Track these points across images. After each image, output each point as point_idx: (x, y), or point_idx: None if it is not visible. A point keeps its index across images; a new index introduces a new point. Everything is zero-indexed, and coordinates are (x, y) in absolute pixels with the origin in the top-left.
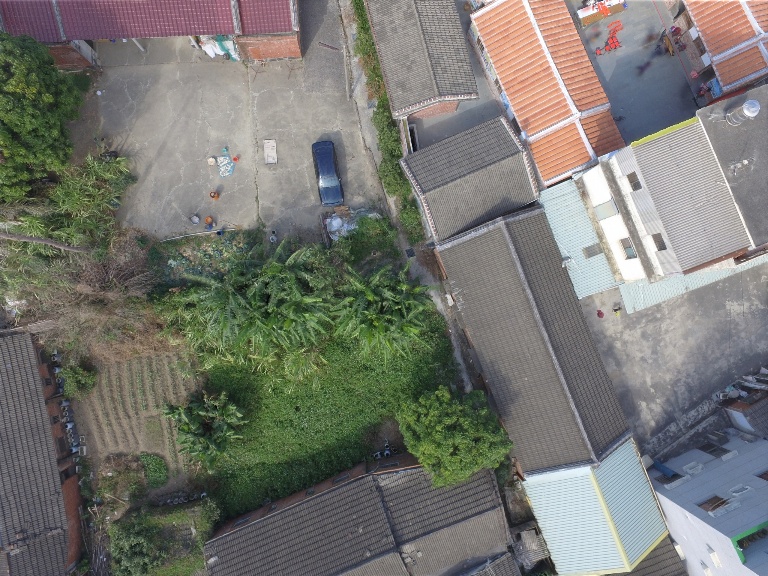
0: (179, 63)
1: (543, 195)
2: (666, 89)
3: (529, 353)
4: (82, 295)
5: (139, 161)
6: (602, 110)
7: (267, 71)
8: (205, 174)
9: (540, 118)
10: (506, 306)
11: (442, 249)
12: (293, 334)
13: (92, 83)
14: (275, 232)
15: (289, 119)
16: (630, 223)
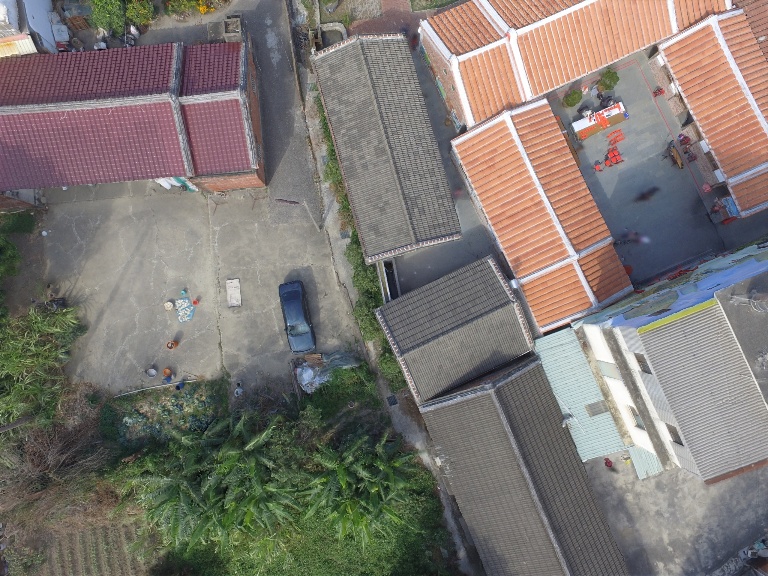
0: (132, 197)
1: (539, 344)
2: (675, 204)
3: (527, 535)
4: (21, 479)
5: (89, 308)
6: (603, 245)
7: (228, 202)
8: (162, 320)
9: (533, 258)
10: (499, 480)
11: (425, 411)
12: (257, 521)
13: (37, 223)
14: (240, 384)
15: (254, 255)
16: (639, 400)
